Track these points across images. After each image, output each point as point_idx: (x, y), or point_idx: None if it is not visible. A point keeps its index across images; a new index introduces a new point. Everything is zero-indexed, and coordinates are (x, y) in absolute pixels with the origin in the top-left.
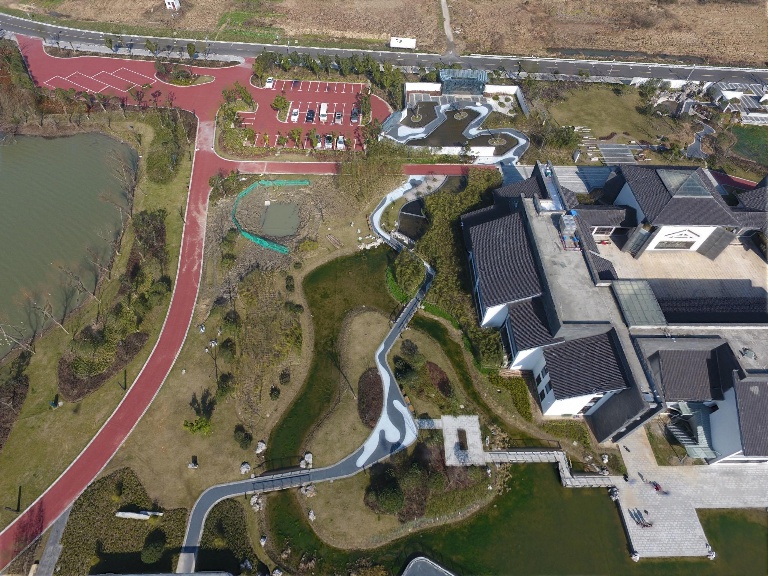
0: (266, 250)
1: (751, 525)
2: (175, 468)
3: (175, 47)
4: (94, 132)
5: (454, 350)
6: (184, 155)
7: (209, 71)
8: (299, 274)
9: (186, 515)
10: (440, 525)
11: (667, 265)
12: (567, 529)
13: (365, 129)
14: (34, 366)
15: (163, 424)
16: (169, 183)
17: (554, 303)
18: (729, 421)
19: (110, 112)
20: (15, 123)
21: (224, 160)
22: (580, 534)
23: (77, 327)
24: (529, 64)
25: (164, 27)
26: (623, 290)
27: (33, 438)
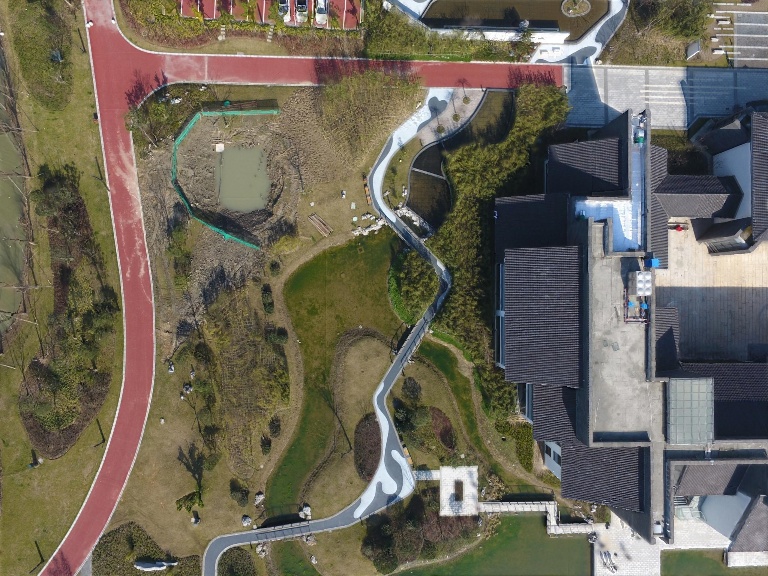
0: (230, 243)
1: (704, 560)
2: (178, 522)
3: None
4: None
5: (462, 386)
6: (71, 40)
7: None
8: (277, 280)
9: (199, 561)
10: (429, 564)
11: (747, 265)
12: (541, 564)
13: None
14: None
15: (155, 480)
16: (65, 107)
17: (589, 414)
18: (729, 512)
19: None
20: None
21: (138, 51)
22: (551, 568)
23: (22, 360)
24: None
25: None
26: (678, 394)
27: (27, 496)
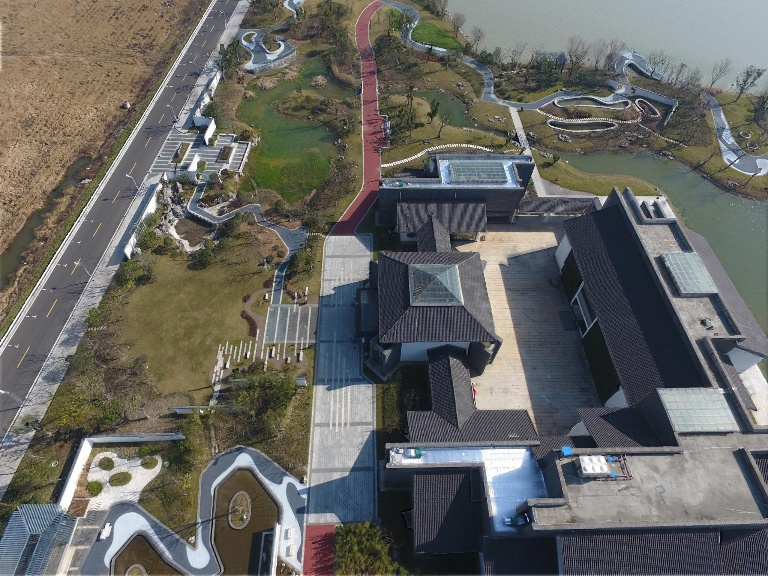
0: None
1: (766, 365)
2: None
3: None
4: None
5: None
6: None
7: None
8: None
9: None
10: None
11: None
12: None
13: None
14: None
15: None
16: None
17: (751, 523)
18: (742, 358)
19: None
20: None
21: None
22: None
23: None
24: None
25: None
26: (686, 423)
27: None
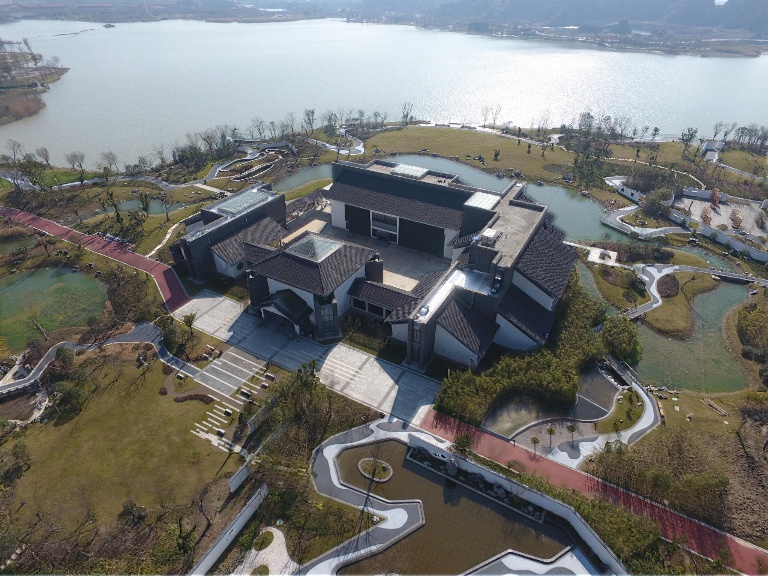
0: None
1: None
2: None
3: None
4: None
5: None
6: None
7: None
8: None
9: None
10: None
11: None
12: None
13: None
14: None
15: None
16: None
17: None
18: None
19: None
20: None
21: None
22: None
23: None
24: None
25: None
26: (487, 205)
27: None
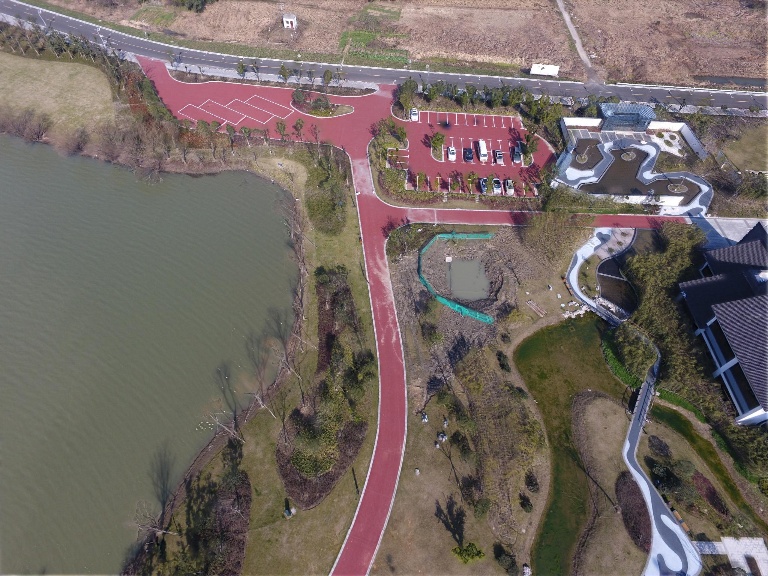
0: (466, 319)
1: None
2: None
3: (303, 71)
4: (240, 169)
5: (706, 449)
6: (346, 200)
7: (346, 100)
8: (508, 348)
9: None
10: None
11: None
12: None
13: (530, 171)
14: (249, 459)
15: (412, 540)
16: (339, 234)
17: None
18: None
19: (254, 147)
20: (157, 158)
21: (390, 206)
22: None
23: (283, 410)
24: (682, 95)
25: (286, 48)
26: None
27: (274, 555)
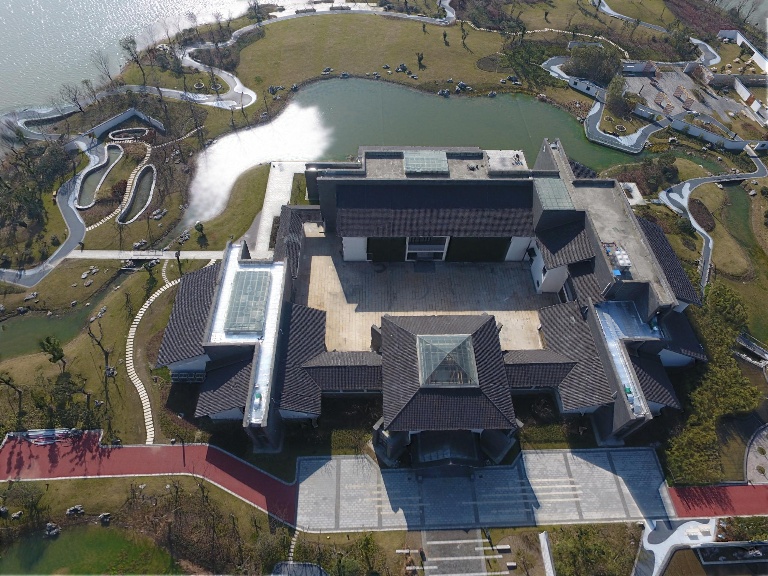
0: None
1: None
2: None
3: None
4: None
5: None
6: None
7: None
8: None
9: None
10: None
11: None
12: None
13: None
14: None
15: None
16: None
17: None
18: None
19: None
20: None
21: None
22: None
23: None
24: None
25: None
26: (566, 202)
27: None
